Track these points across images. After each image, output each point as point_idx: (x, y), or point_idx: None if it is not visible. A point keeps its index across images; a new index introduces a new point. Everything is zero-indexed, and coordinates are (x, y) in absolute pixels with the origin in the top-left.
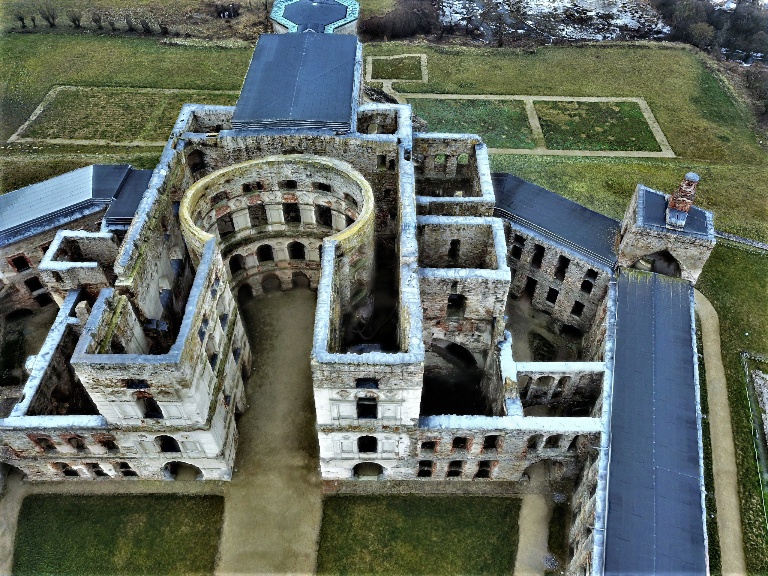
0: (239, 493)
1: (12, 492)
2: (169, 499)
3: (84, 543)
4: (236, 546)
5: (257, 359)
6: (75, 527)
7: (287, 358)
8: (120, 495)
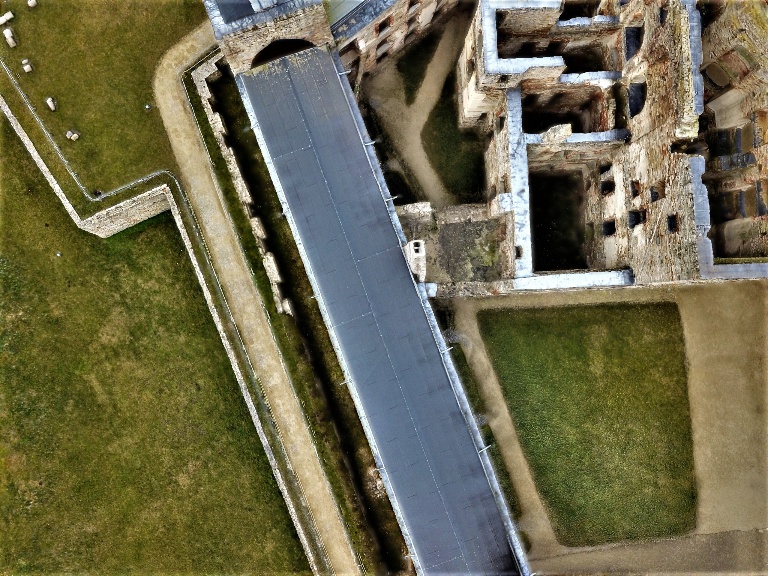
0: (691, 299)
1: (461, 309)
2: (622, 308)
3: (556, 356)
4: (701, 351)
5: None
6: (540, 341)
7: None
8: (571, 306)
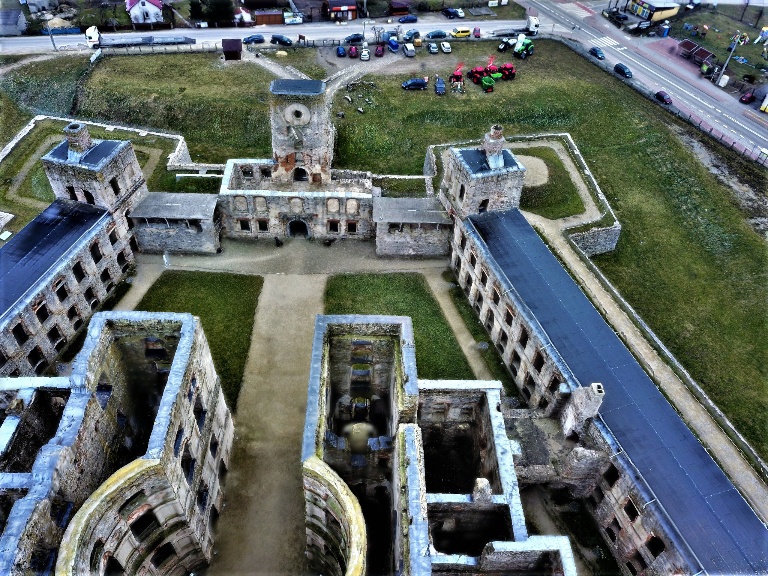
0: None
1: None
2: None
3: None
4: None
5: (304, 567)
6: None
7: (266, 570)
8: None
